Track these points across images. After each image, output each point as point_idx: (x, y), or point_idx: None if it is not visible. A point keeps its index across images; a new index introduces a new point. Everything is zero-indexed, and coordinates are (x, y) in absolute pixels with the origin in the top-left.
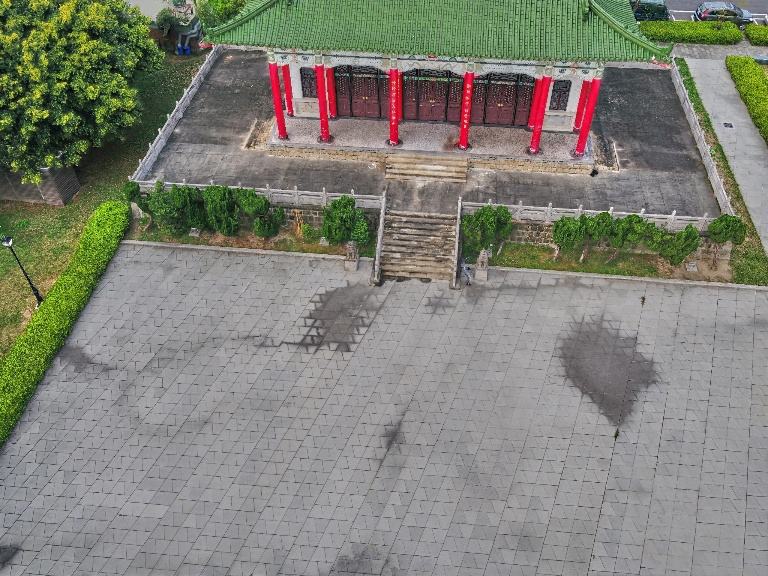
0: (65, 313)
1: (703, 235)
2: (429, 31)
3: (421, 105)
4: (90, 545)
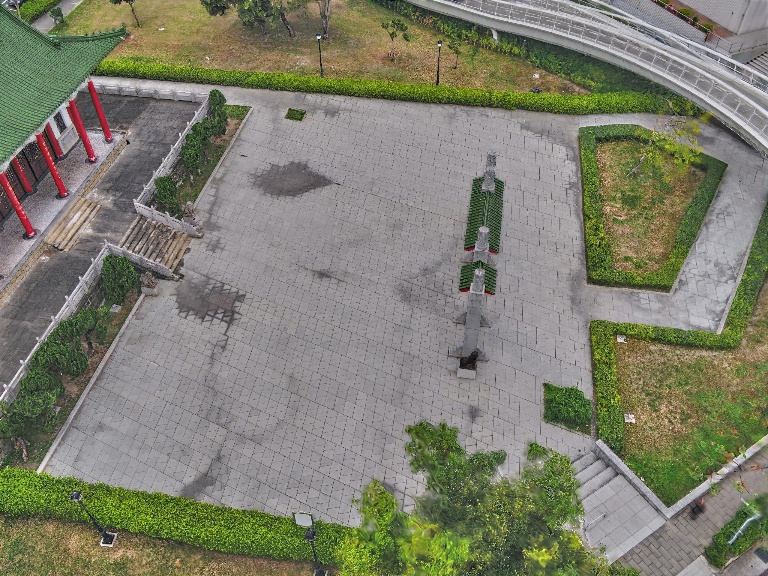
0: (143, 497)
1: (210, 113)
2: (6, 122)
3: None
4: (384, 435)
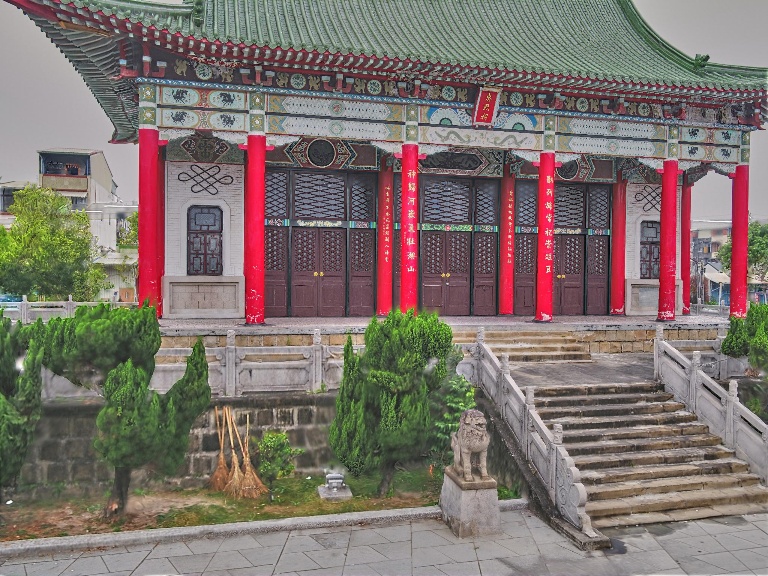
0: None
1: None
2: None
3: (425, 284)
4: None
